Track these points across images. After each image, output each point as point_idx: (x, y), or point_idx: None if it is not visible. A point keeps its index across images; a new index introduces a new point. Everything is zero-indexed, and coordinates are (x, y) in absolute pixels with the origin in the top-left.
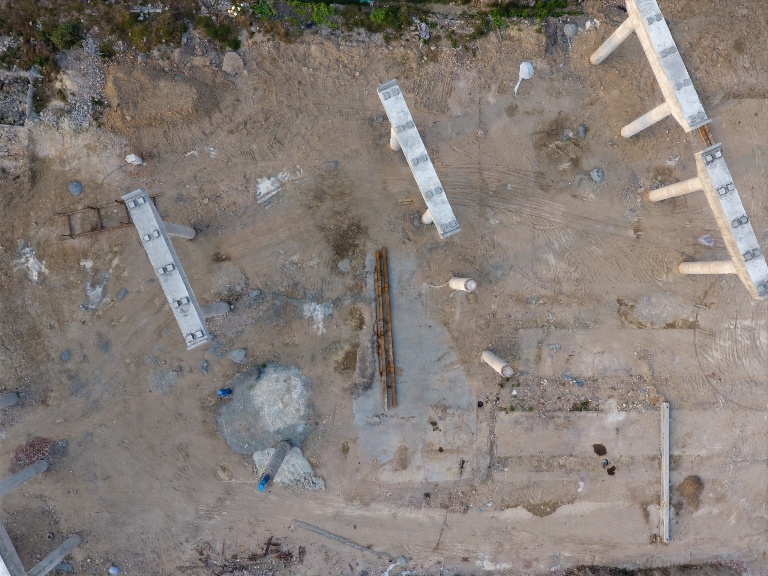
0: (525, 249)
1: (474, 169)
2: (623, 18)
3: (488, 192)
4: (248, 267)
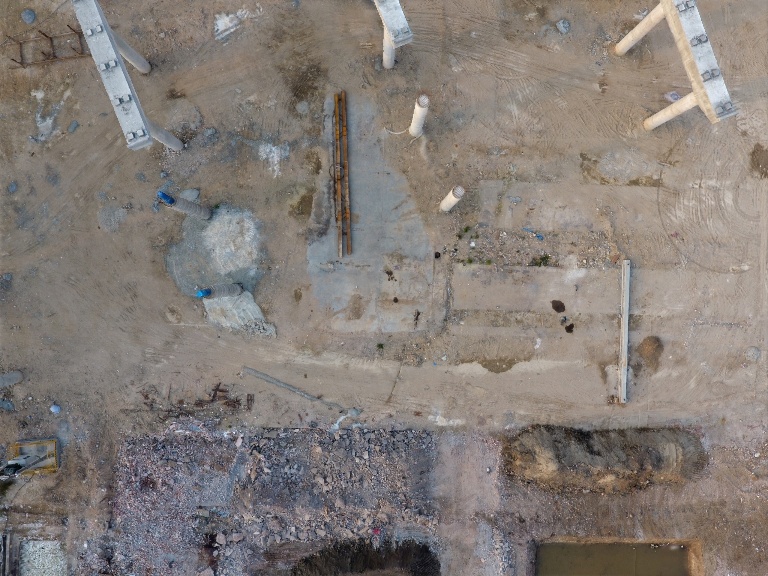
0: (488, 98)
1: (438, 15)
2: None
3: (451, 39)
4: (203, 105)
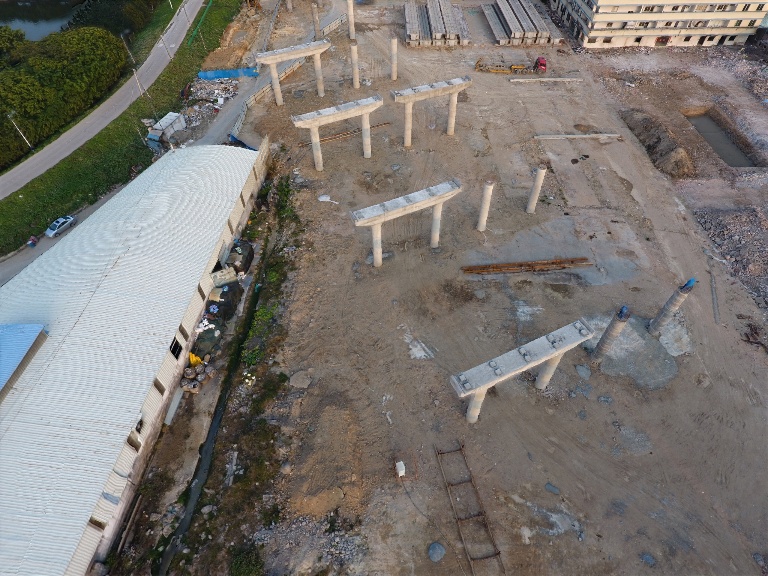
0: None
1: (394, 221)
2: (295, 159)
3: (411, 214)
4: None
